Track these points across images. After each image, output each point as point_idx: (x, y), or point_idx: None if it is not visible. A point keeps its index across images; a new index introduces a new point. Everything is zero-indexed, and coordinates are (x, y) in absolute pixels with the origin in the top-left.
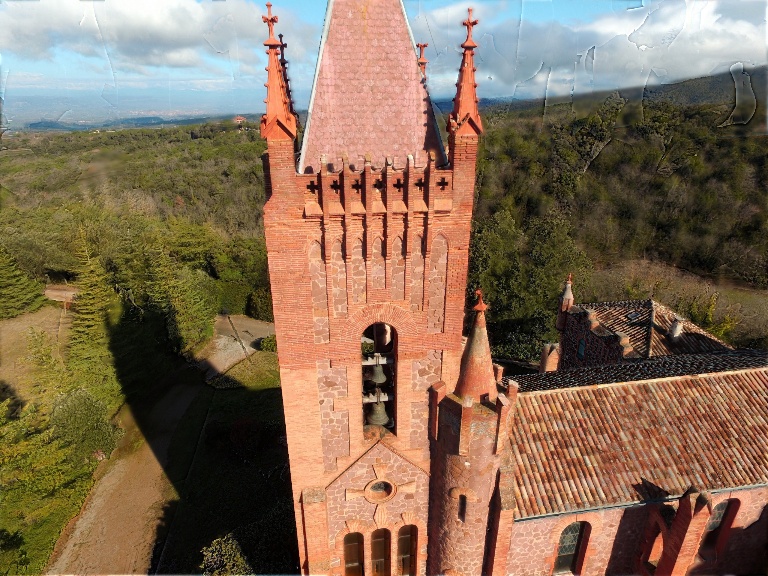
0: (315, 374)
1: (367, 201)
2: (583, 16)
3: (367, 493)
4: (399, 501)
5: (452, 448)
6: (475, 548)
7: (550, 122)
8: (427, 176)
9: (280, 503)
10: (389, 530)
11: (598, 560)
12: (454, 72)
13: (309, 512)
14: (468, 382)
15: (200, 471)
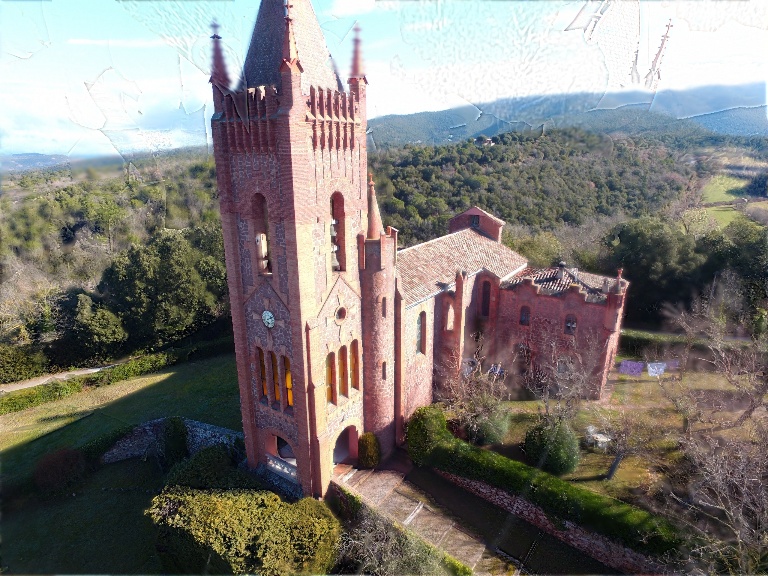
0: (311, 228)
1: (332, 114)
2: None
3: (335, 318)
4: (349, 322)
5: (376, 268)
6: (391, 335)
7: None
8: (351, 103)
9: (179, 464)
10: (346, 347)
11: (430, 338)
12: (114, 101)
13: (312, 337)
14: (374, 227)
15: (12, 535)
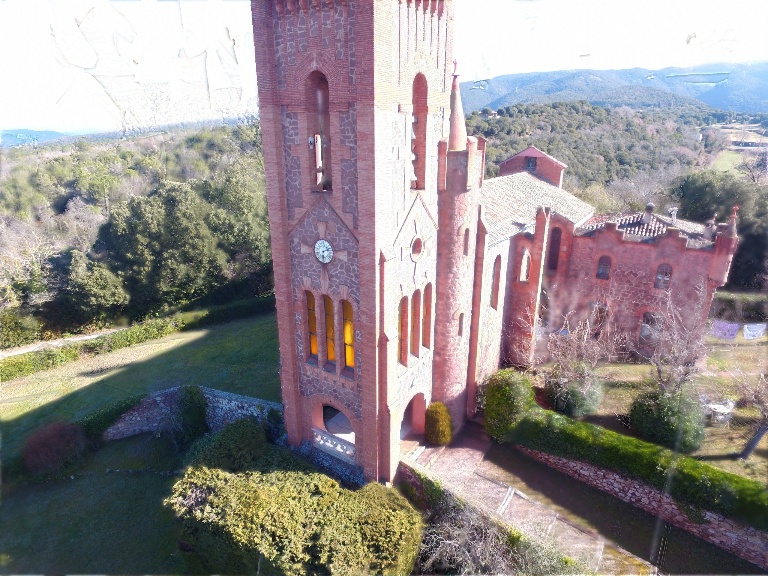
0: (391, 117)
1: None
2: (229, 4)
3: (411, 251)
4: (424, 259)
5: (460, 188)
6: (471, 280)
7: (216, 106)
8: None
9: (202, 441)
10: (420, 291)
11: (502, 290)
12: (107, 42)
13: (387, 272)
14: (458, 135)
15: None
